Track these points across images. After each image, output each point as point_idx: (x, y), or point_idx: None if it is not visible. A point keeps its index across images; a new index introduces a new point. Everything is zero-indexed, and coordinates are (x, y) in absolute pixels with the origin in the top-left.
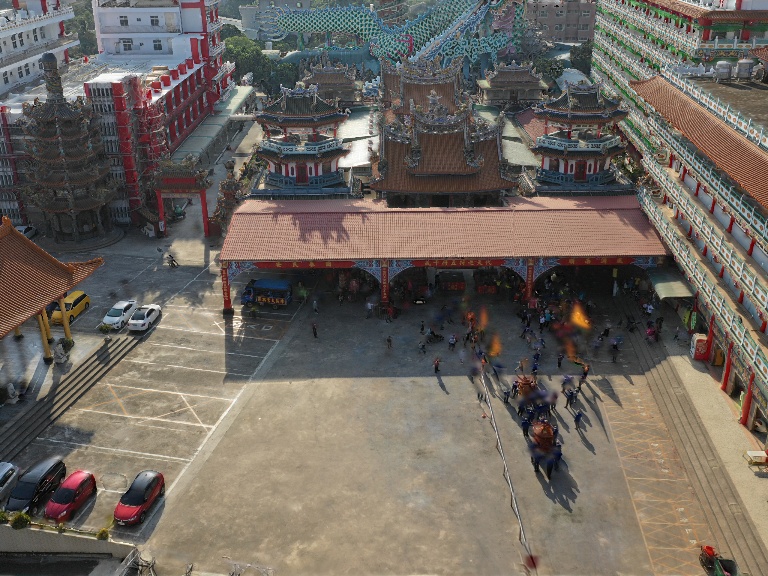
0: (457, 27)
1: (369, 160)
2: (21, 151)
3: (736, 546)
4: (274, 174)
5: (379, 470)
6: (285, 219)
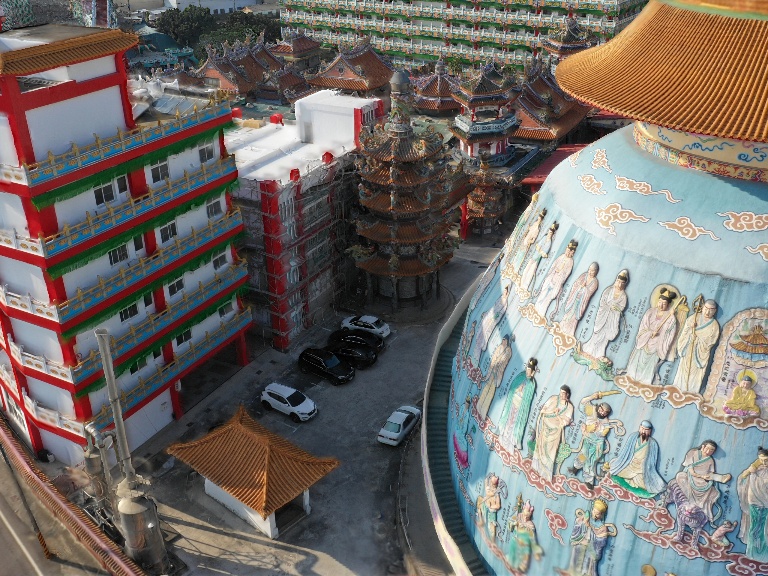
0: (95, 12)
1: None
2: (307, 227)
3: None
4: None
5: None
6: None
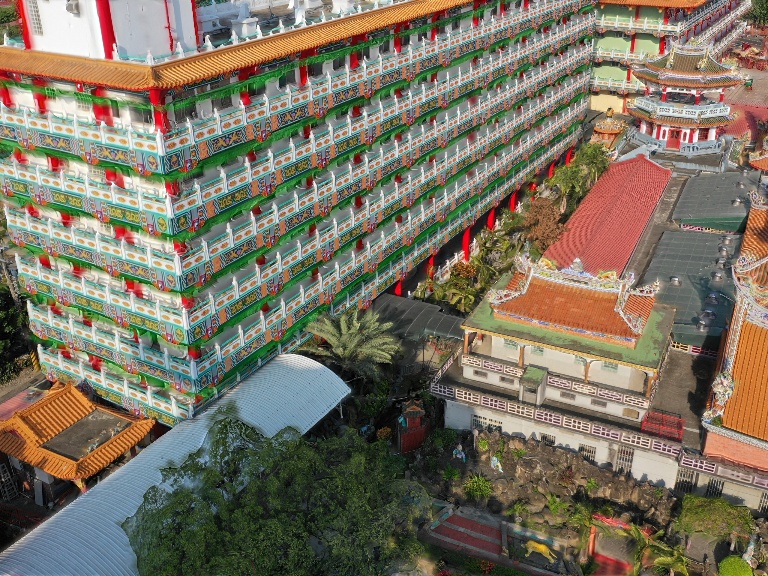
0: None
1: None
2: None
3: None
4: None
5: None
6: None
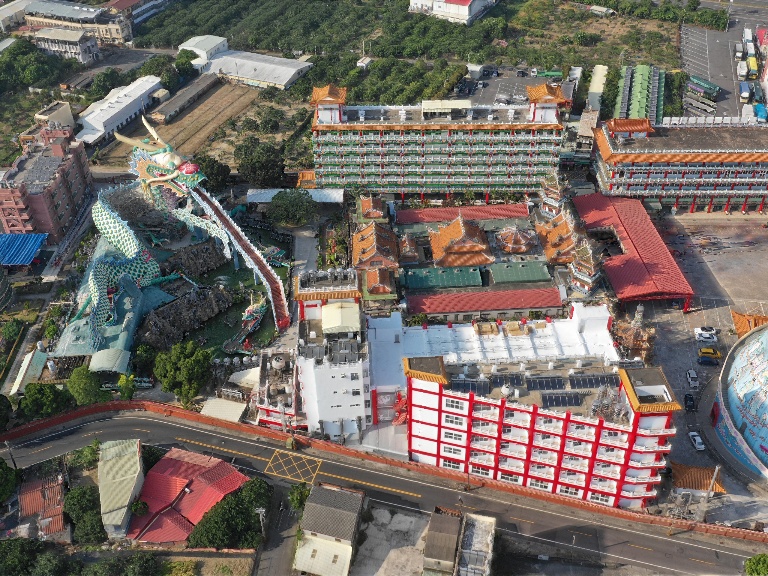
0: None
1: (545, 265)
2: None
3: (759, 222)
4: (591, 289)
5: (762, 271)
6: (656, 278)
